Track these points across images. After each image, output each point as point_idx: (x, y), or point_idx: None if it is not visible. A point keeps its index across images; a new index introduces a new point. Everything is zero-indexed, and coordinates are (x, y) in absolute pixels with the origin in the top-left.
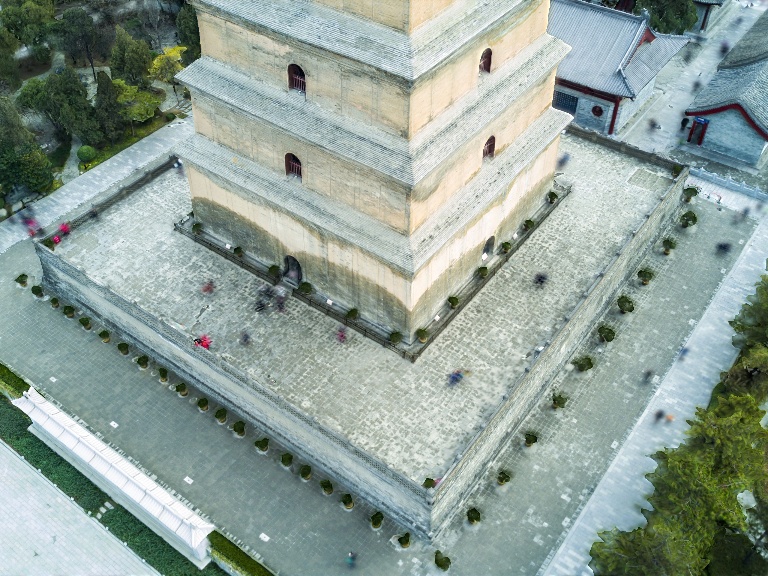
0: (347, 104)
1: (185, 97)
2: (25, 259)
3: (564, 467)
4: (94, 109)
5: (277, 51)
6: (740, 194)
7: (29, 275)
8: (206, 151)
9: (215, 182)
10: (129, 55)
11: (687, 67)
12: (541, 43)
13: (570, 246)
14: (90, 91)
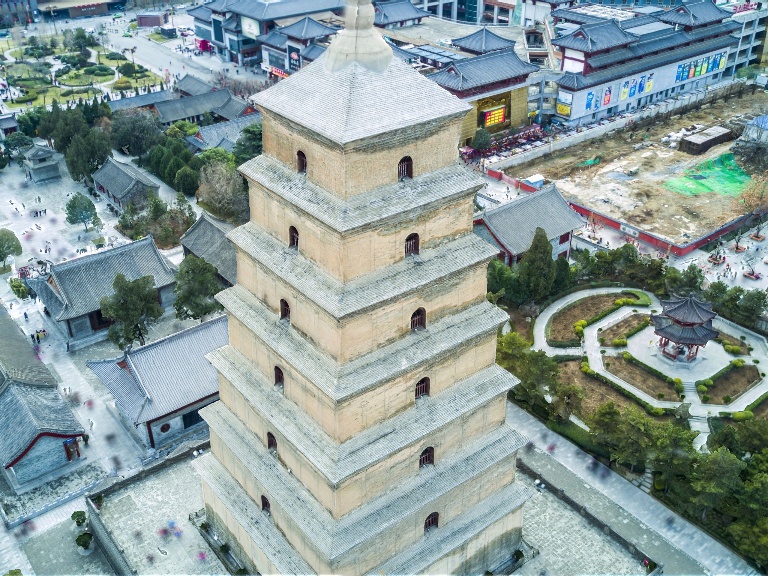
0: None
1: None
2: None
3: (603, 515)
4: None
5: None
6: None
7: None
8: None
9: None
10: None
11: None
12: None
13: None
14: None
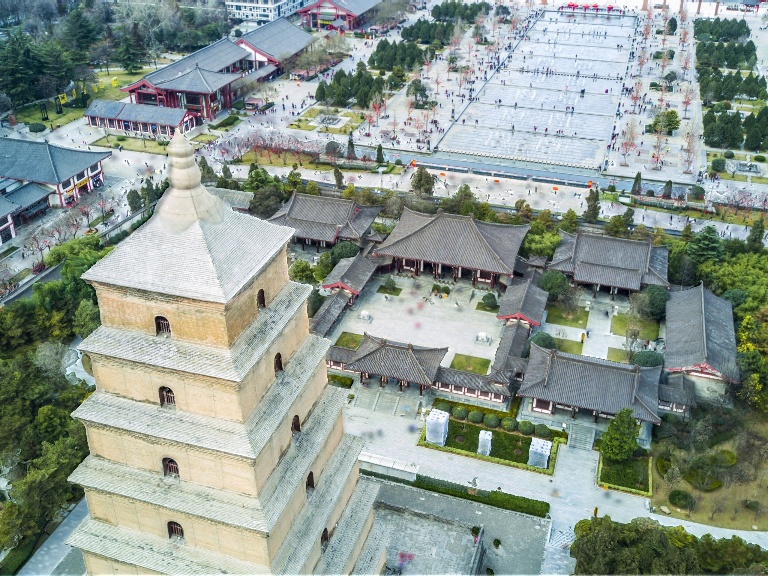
0: None
1: None
2: (518, 568)
3: None
4: None
5: None
6: None
7: (502, 555)
8: None
9: None
10: None
11: None
12: None
13: None
14: None
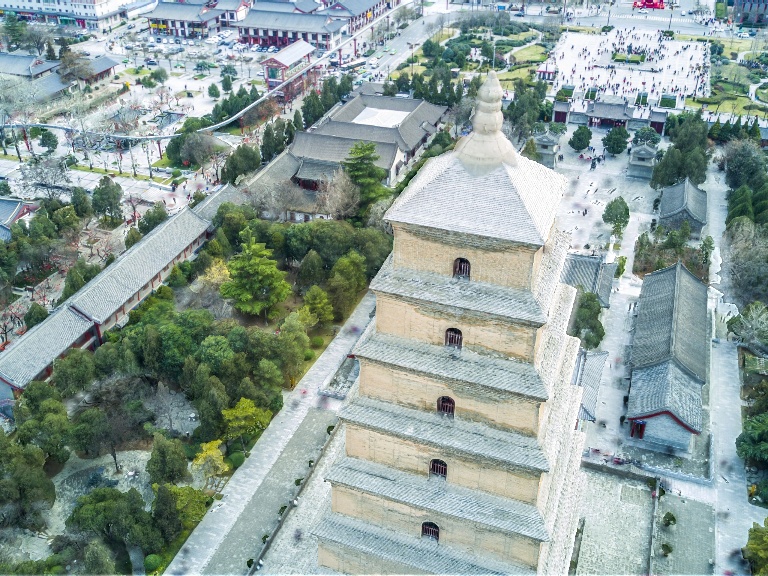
0: (480, 548)
1: None
2: None
3: None
4: (154, 519)
5: (413, 513)
6: (691, 483)
7: None
8: None
9: None
10: (171, 458)
11: None
12: None
13: None
14: None
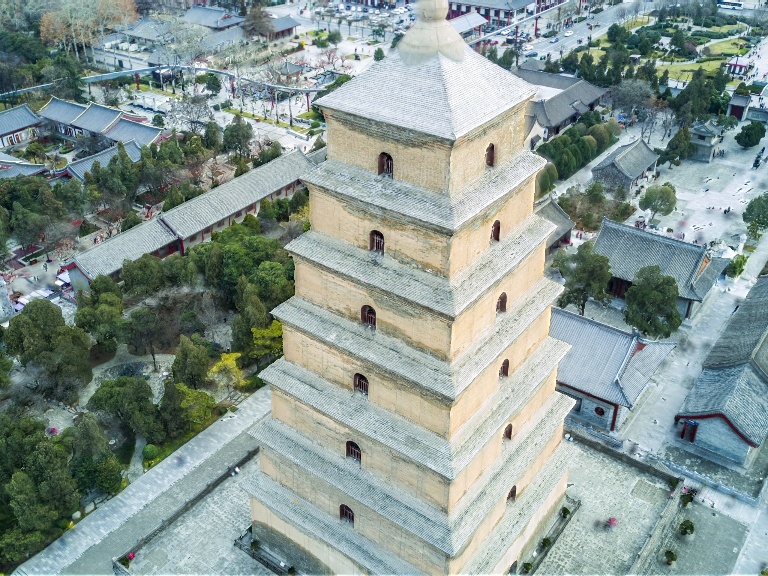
0: (396, 478)
1: (235, 388)
2: (98, 566)
3: None
4: (160, 412)
5: (338, 430)
6: (731, 498)
7: None
8: (269, 489)
9: (275, 514)
10: (191, 361)
11: (676, 356)
12: (551, 402)
13: (583, 565)
14: (151, 381)
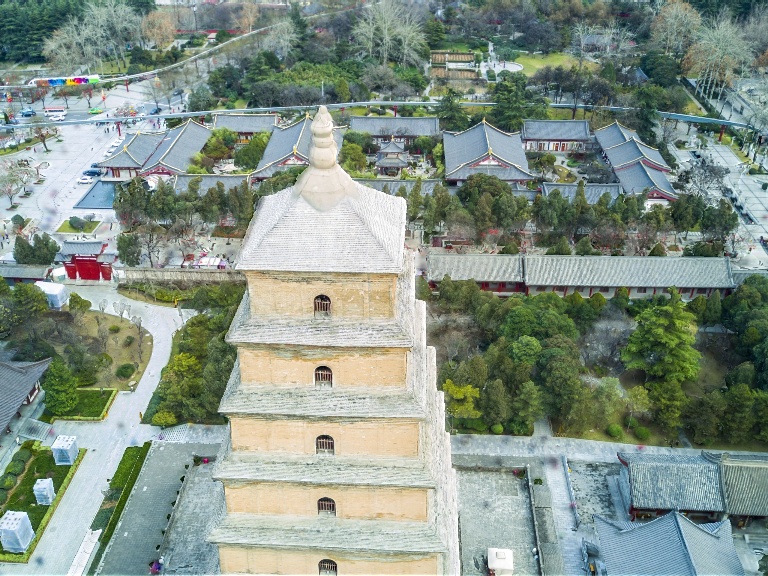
0: None
1: None
2: None
3: None
4: None
5: None
6: None
7: None
8: None
9: None
10: None
11: None
12: None
13: None
14: None
